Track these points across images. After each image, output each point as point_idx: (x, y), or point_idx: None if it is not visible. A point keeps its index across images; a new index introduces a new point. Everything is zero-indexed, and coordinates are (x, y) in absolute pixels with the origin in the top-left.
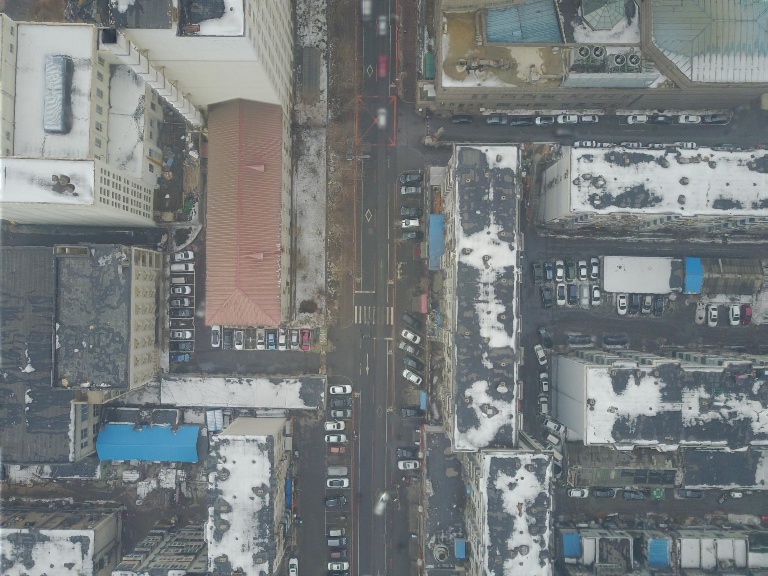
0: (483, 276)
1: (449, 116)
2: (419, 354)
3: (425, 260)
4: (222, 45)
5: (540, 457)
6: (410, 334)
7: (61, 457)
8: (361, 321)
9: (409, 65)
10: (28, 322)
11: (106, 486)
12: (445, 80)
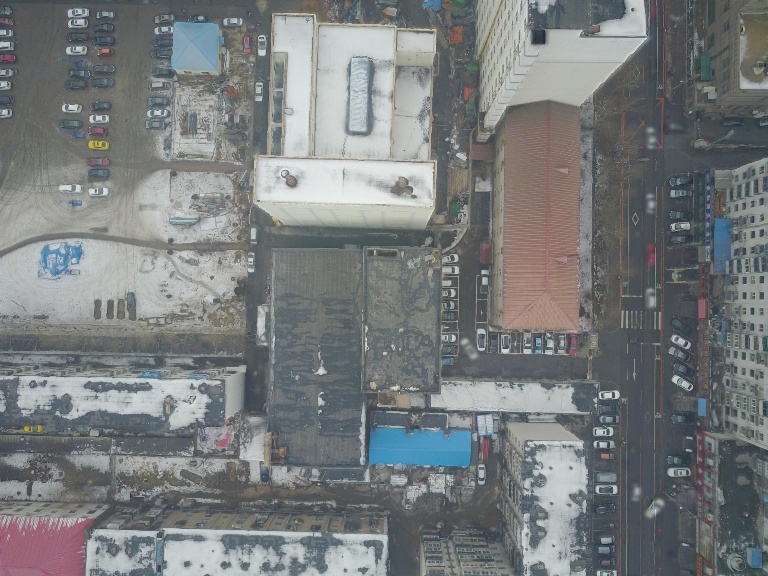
0: None
1: (718, 119)
2: (689, 360)
3: (696, 264)
4: (612, 46)
5: None
6: (681, 339)
7: (353, 460)
8: (628, 326)
9: (678, 67)
10: (321, 324)
11: (369, 490)
12: (742, 82)
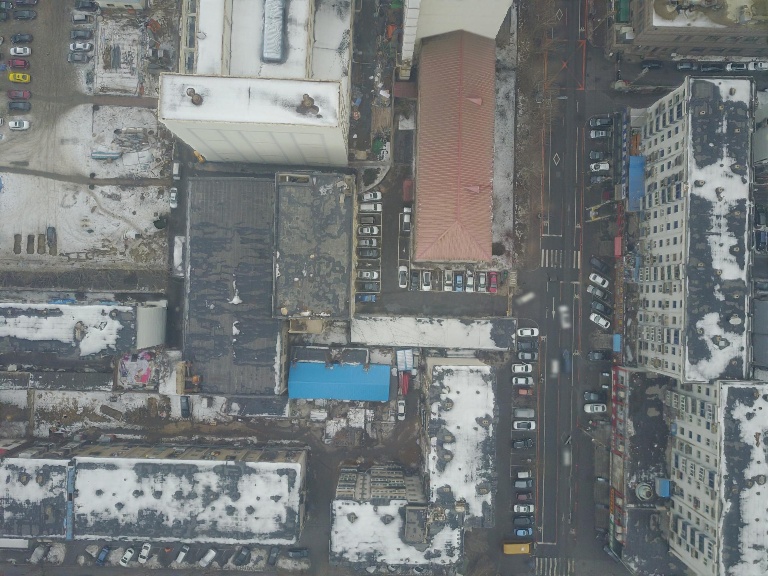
0: (716, 208)
1: (639, 61)
2: (607, 298)
3: (614, 204)
4: None
5: None
6: (599, 277)
7: (267, 390)
8: (548, 264)
9: (599, 9)
10: (236, 253)
11: (290, 426)
12: (656, 19)
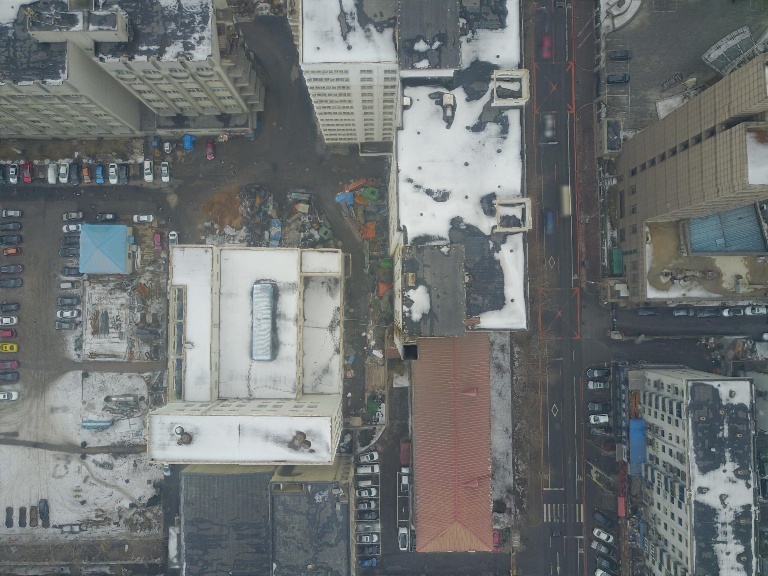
0: (721, 516)
1: (634, 308)
2: (612, 553)
3: (615, 457)
4: None
5: None
6: (603, 534)
7: None
8: (550, 519)
9: (592, 257)
10: (232, 550)
11: None
12: (650, 291)
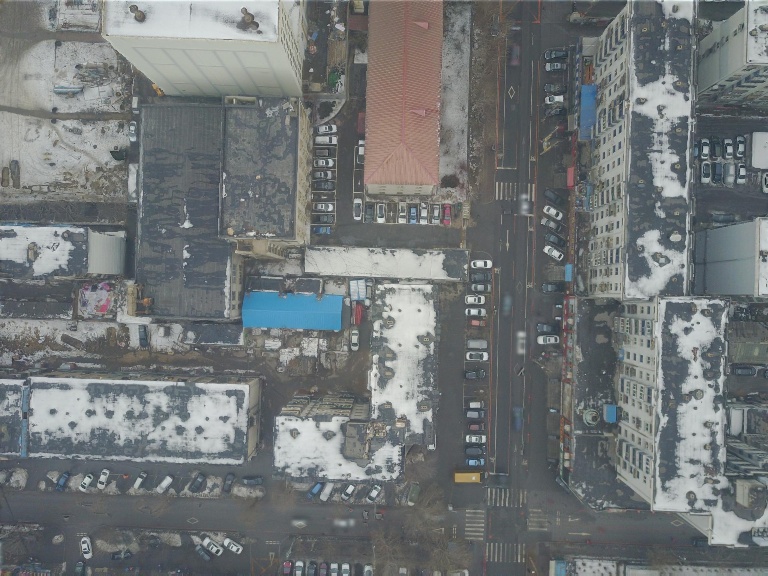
0: (657, 126)
1: None
2: (561, 230)
3: (569, 136)
4: None
5: (716, 302)
6: (553, 209)
7: (217, 313)
8: (502, 197)
9: None
10: (187, 178)
11: (246, 356)
12: None
